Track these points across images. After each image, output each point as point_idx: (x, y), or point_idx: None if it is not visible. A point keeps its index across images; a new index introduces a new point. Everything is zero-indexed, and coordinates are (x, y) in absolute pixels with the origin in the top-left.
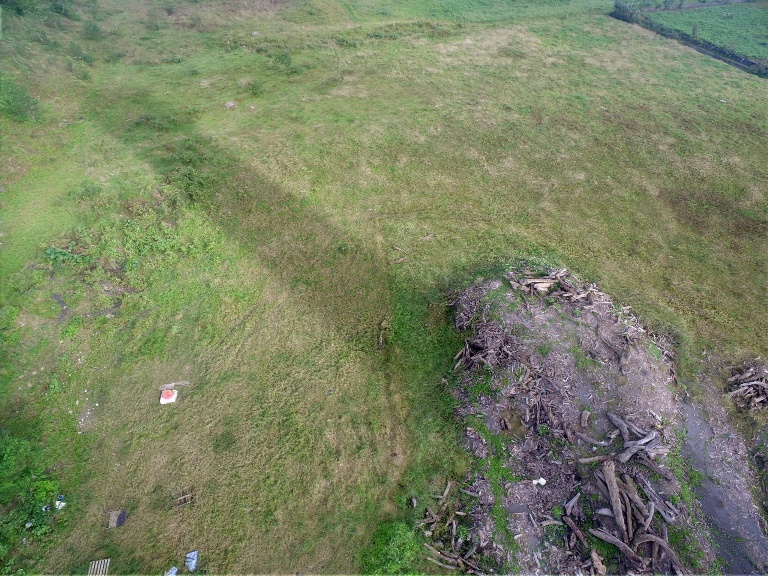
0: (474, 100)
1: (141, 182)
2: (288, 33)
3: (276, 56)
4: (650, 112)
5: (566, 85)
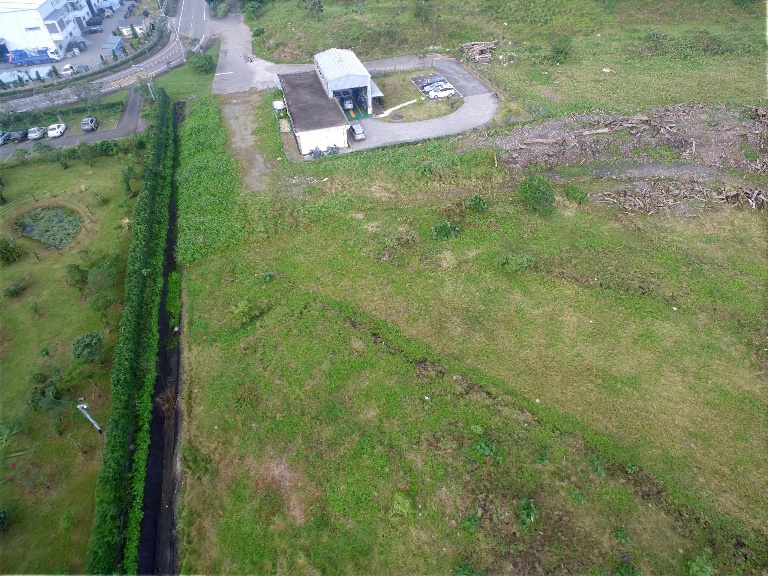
0: None
1: (726, 38)
2: None
3: None
4: None
5: None
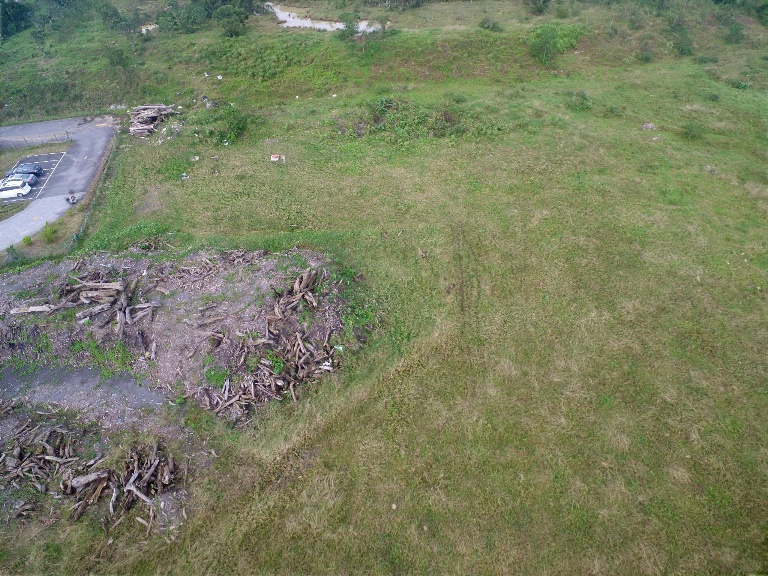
0: None
1: (473, 110)
2: None
3: None
4: None
5: None
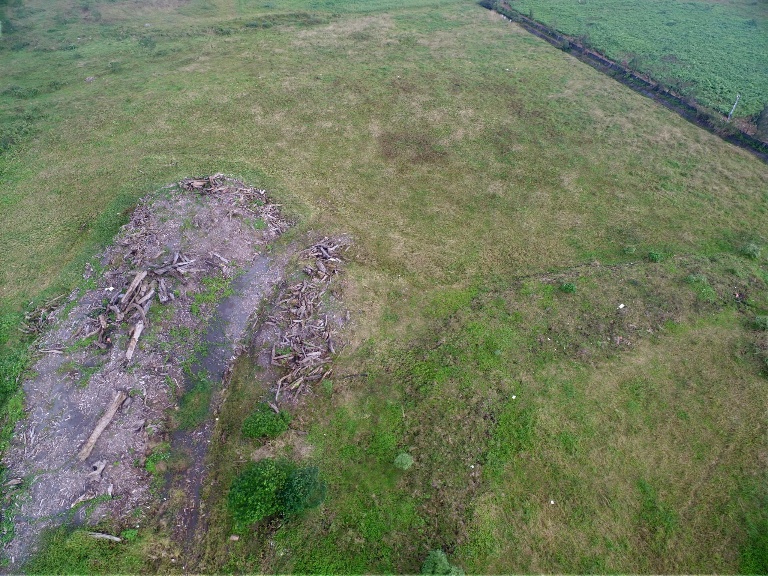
0: (294, 72)
1: None
2: (175, 24)
3: (140, 40)
4: (434, 79)
5: (382, 60)
